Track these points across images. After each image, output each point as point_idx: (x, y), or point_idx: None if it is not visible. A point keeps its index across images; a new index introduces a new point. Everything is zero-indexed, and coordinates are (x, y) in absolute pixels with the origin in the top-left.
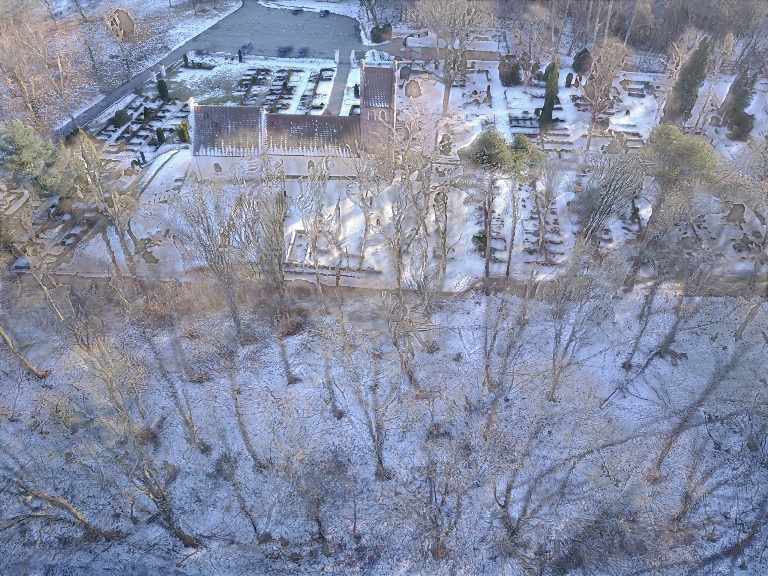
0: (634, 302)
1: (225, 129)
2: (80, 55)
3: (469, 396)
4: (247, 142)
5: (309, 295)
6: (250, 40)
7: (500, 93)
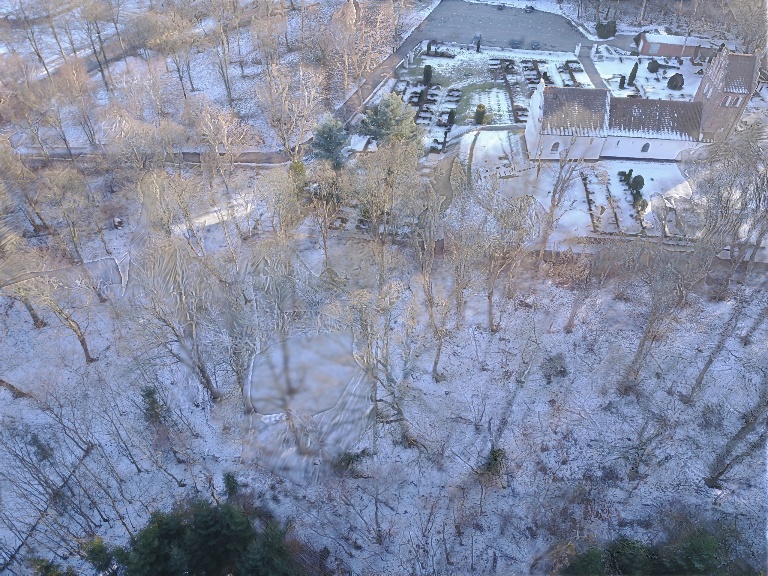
0: None
1: (572, 110)
2: (313, 40)
3: None
4: (593, 123)
5: None
6: (473, 32)
7: (764, 89)
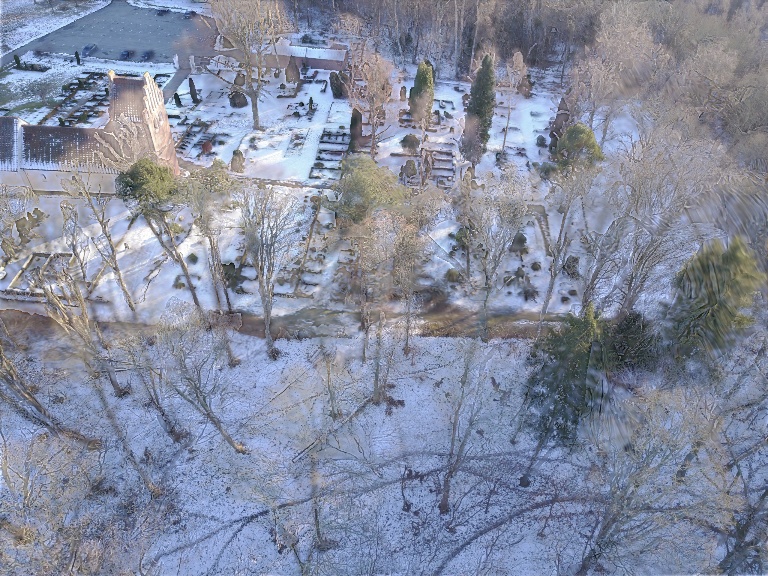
0: (363, 342)
1: None
2: None
3: (150, 446)
4: (1, 155)
5: (18, 327)
6: (99, 41)
7: (327, 105)
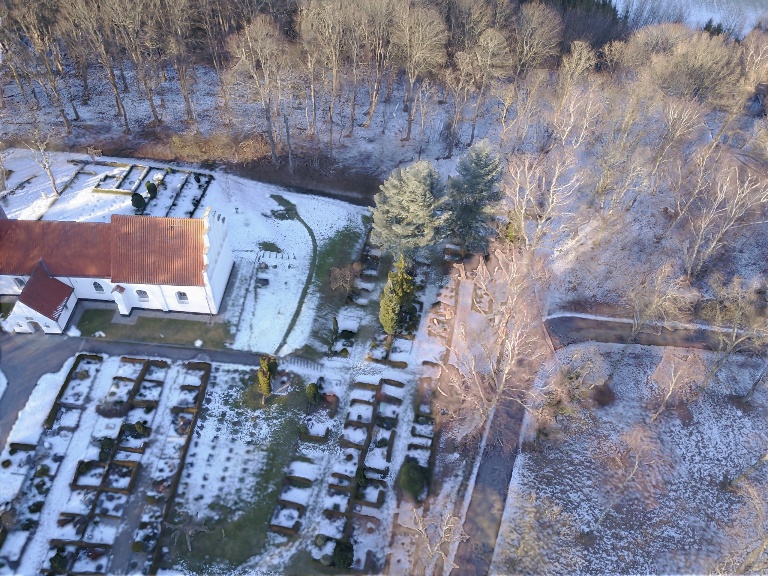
0: None
1: None
2: None
3: None
4: None
5: None
6: None
7: None
